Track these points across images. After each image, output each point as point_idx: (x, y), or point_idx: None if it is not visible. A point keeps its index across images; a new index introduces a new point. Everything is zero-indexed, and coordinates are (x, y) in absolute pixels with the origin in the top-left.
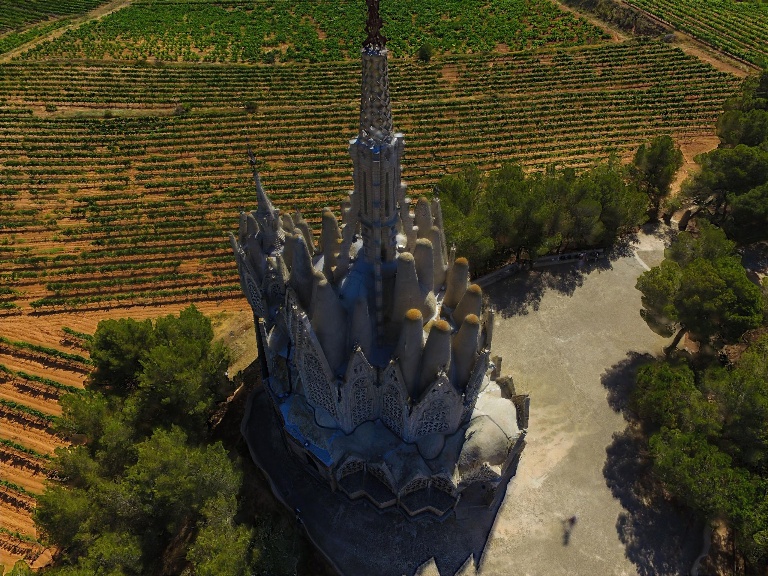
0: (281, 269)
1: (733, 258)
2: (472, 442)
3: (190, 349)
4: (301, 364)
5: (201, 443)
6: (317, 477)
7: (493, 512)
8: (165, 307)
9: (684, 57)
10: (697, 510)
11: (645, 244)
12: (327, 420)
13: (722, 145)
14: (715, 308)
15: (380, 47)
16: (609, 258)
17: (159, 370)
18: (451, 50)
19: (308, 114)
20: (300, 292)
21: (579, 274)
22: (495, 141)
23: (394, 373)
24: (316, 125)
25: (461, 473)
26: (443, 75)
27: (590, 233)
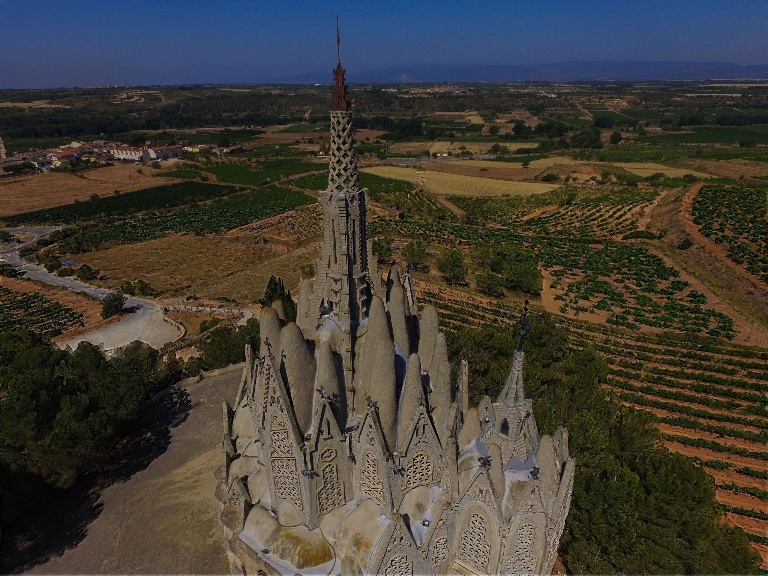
0: None
1: None
2: None
3: None
4: None
5: None
6: None
7: None
8: None
9: None
10: None
11: None
12: None
13: None
14: None
15: None
16: None
17: None
18: None
19: None
20: None
21: None
22: None
23: None
24: None
25: None
26: None
27: None
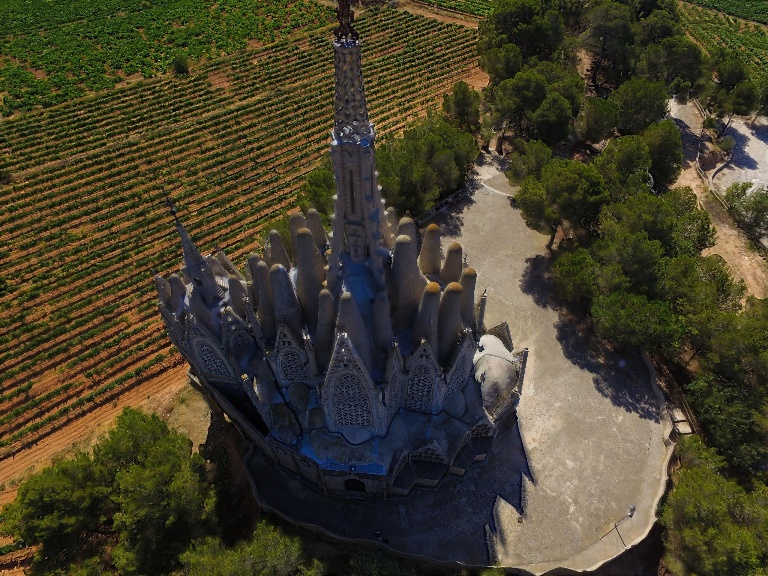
0: (253, 312)
1: (556, 160)
2: (488, 381)
3: (165, 452)
4: (329, 392)
5: (222, 543)
6: (363, 497)
7: (516, 432)
8: (44, 442)
9: (414, 18)
10: (631, 348)
11: (485, 174)
12: (362, 435)
13: (494, 79)
14: (581, 197)
15: (357, 37)
16: (468, 195)
17: (142, 494)
18: (204, 57)
19: (86, 163)
20: (289, 325)
21: (456, 216)
22: (305, 131)
23: (425, 352)
24: (103, 172)
25: (491, 412)
26: (212, 83)
27: (451, 179)
